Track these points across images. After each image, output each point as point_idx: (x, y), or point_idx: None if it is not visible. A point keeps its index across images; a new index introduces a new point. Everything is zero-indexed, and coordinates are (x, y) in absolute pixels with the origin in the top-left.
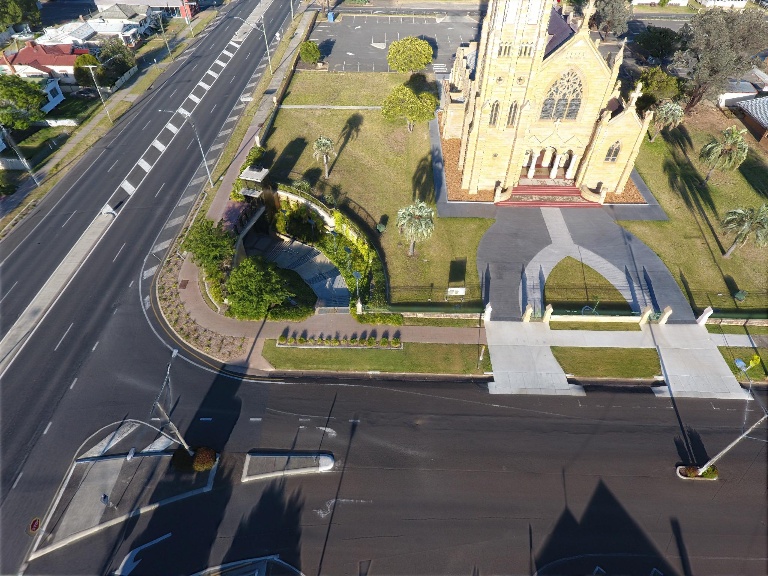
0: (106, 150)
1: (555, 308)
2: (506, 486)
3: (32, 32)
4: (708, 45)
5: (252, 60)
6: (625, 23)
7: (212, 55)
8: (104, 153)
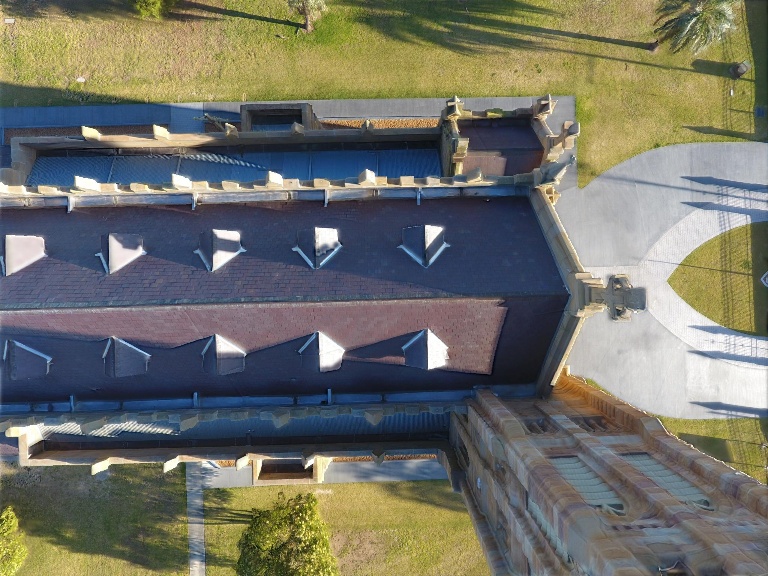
0: None
1: (767, 323)
2: None
3: None
4: None
5: None
6: None
7: None
8: None
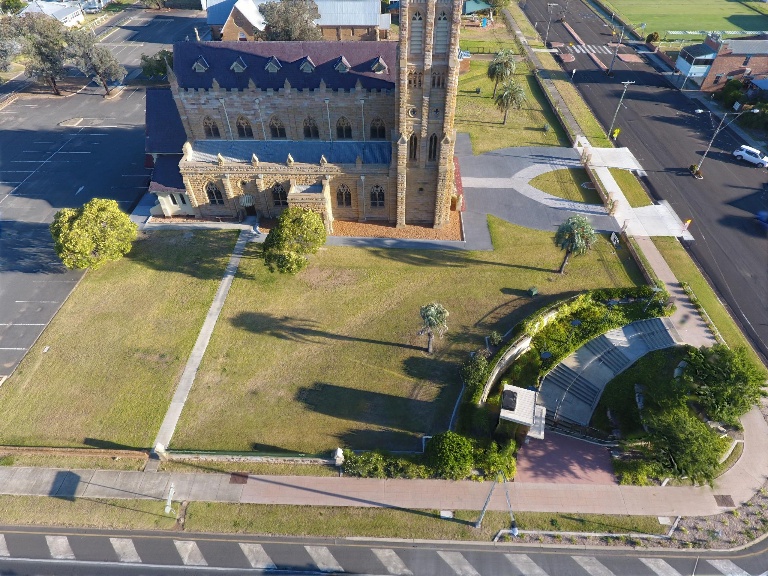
0: None
1: (591, 199)
2: (763, 239)
3: None
4: (303, 30)
5: None
6: (118, 66)
7: None
8: None
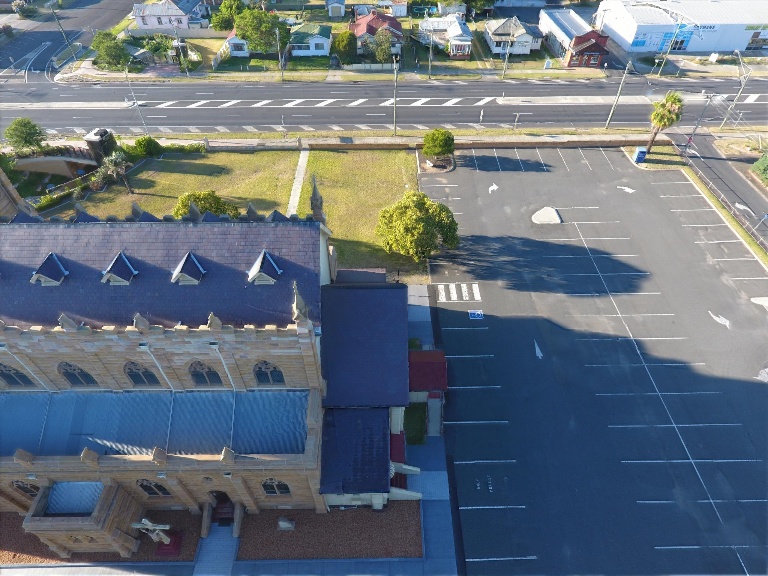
0: (234, 87)
1: None
2: None
3: (471, 16)
4: None
5: (437, 118)
6: None
7: (444, 94)
8: (229, 87)
